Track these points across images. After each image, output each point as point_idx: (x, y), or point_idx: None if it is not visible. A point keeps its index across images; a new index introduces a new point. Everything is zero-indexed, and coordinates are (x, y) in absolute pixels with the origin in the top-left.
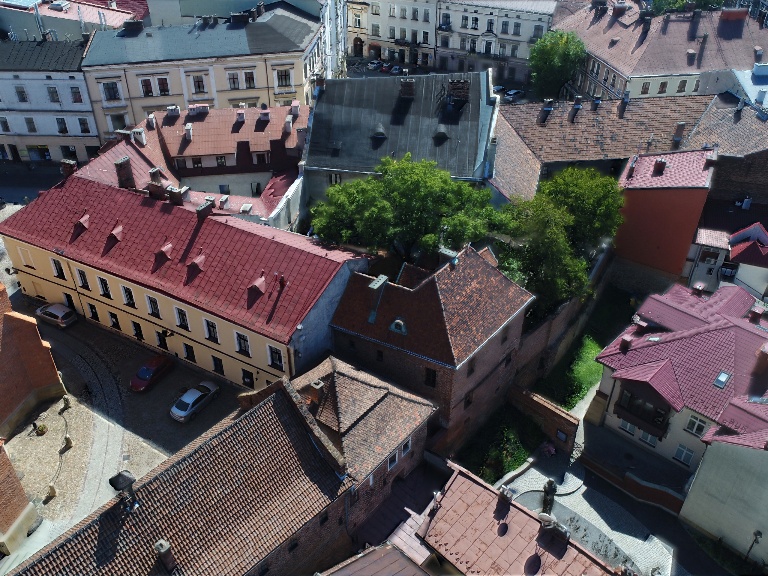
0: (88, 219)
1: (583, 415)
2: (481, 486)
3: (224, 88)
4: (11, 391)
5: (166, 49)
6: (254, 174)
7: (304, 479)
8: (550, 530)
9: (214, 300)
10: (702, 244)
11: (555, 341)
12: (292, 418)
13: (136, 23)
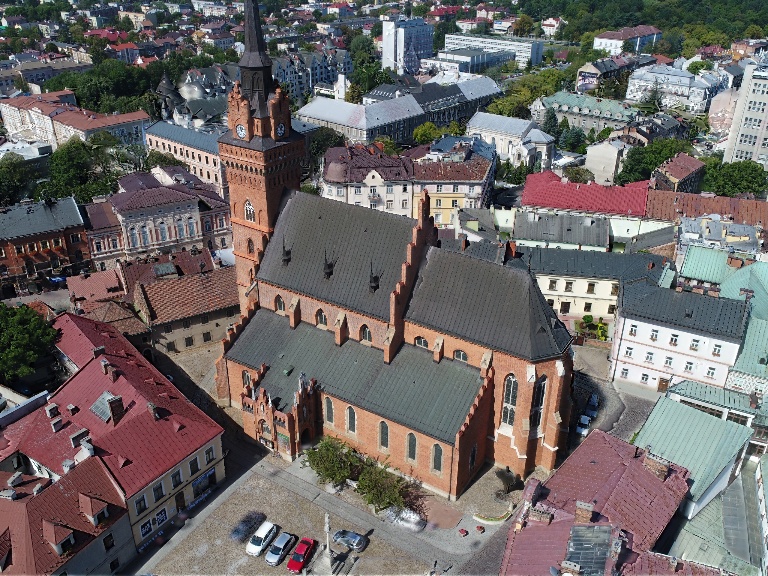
0: None
1: None
2: None
3: None
4: None
5: None
6: None
7: None
8: None
9: (128, 347)
10: None
11: None
12: None
13: None
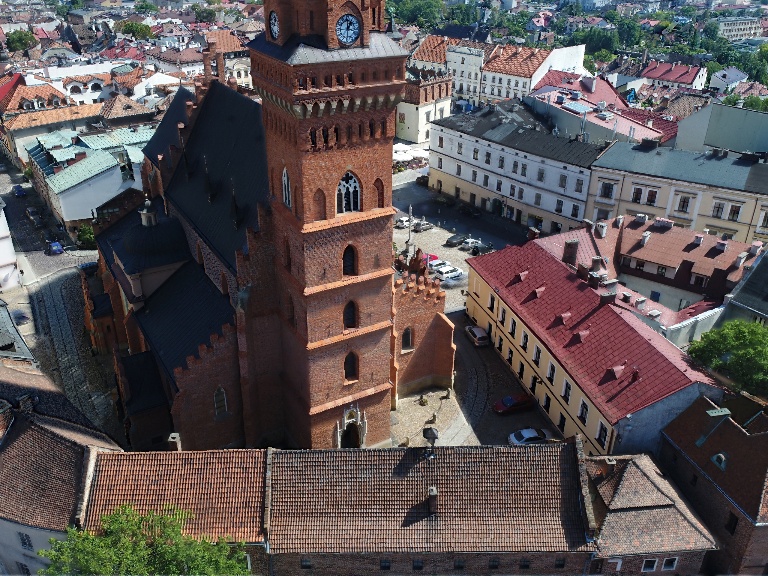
0: (526, 274)
1: None
2: None
3: (706, 213)
4: (419, 366)
5: (667, 168)
6: (687, 292)
7: (557, 520)
8: None
9: (578, 367)
10: None
11: None
12: (571, 470)
13: (652, 142)
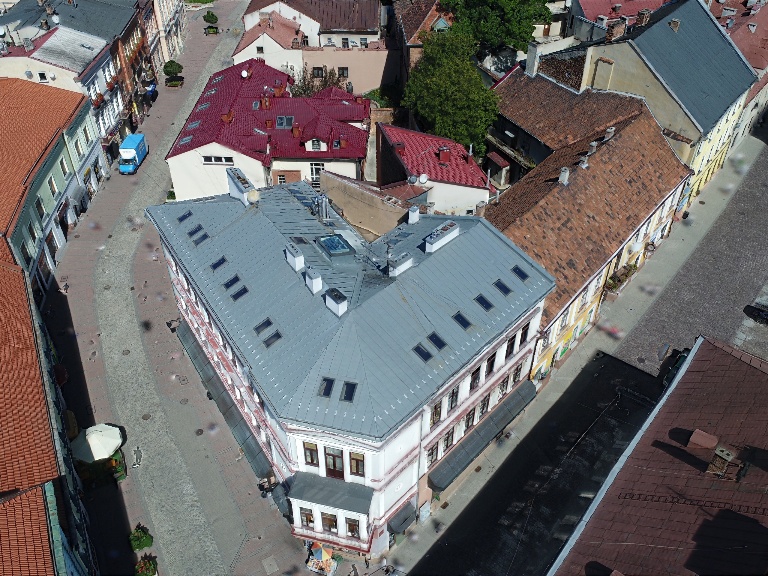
0: None
1: None
2: None
3: None
4: None
5: None
6: None
7: None
8: None
9: None
10: None
11: None
12: None
13: None
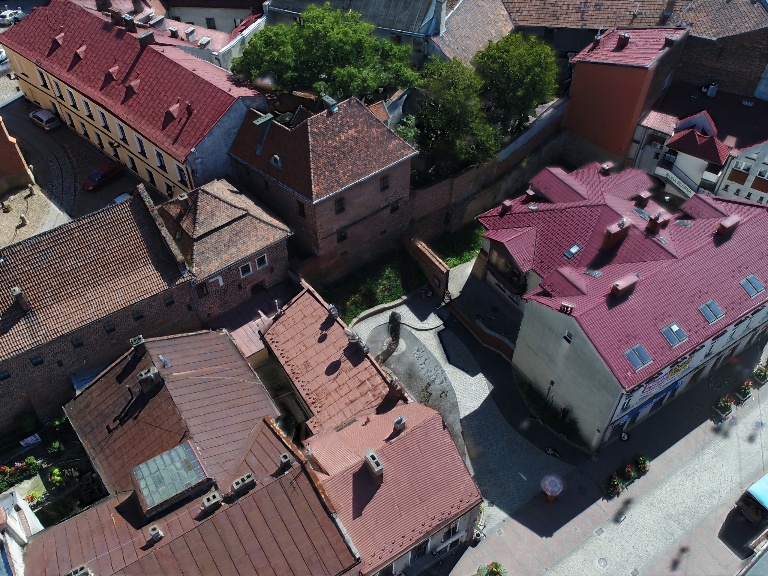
0: (63, 37)
1: (471, 269)
2: (320, 303)
3: None
4: None
5: None
6: (236, 10)
7: (150, 267)
8: (355, 344)
9: (140, 119)
10: (647, 127)
11: (462, 199)
12: (146, 219)
13: None
